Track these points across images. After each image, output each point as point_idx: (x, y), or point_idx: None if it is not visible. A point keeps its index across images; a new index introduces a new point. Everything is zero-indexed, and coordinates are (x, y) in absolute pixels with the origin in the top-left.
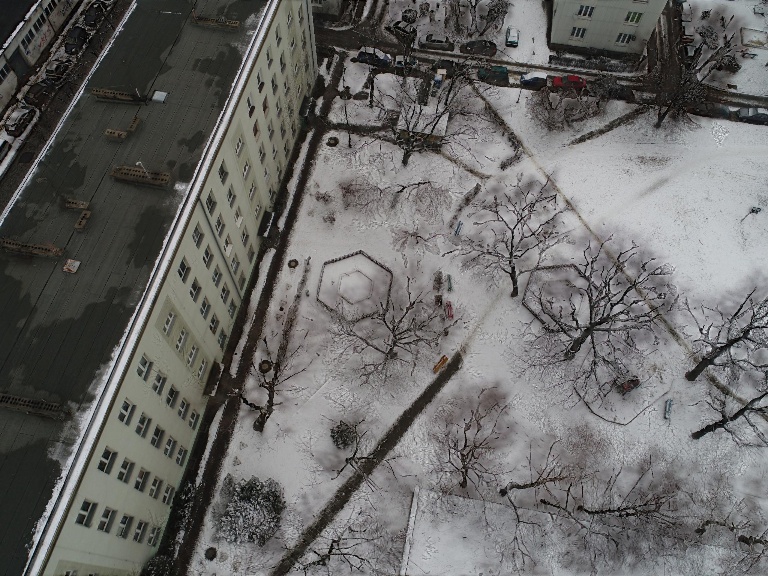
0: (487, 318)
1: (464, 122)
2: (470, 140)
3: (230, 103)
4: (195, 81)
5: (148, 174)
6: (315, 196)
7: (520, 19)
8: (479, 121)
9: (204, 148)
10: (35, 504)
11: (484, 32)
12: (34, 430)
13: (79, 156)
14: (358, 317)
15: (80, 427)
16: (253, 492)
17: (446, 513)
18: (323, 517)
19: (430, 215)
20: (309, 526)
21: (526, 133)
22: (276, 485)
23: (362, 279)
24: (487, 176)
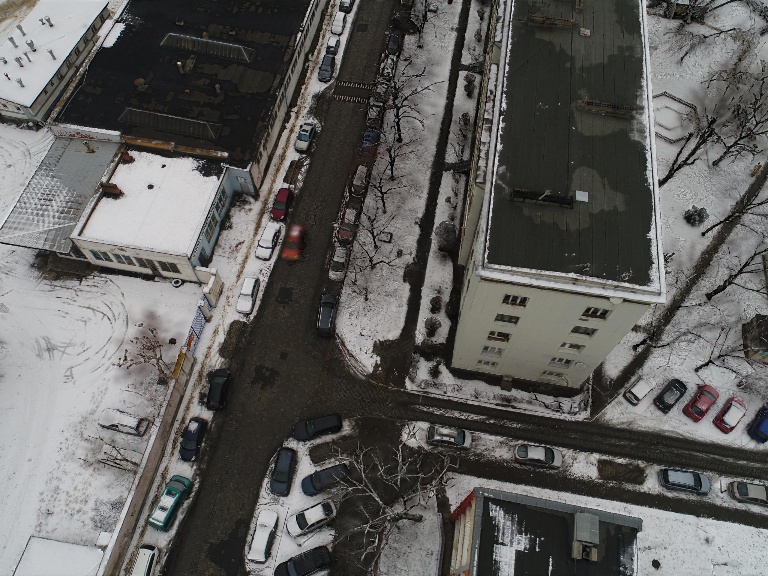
0: None
1: (717, 2)
2: (727, 15)
3: None
4: None
5: None
6: None
7: None
8: None
9: None
10: (639, 163)
11: None
12: (614, 124)
13: None
14: None
15: (644, 123)
16: None
17: None
18: (696, 270)
19: (743, 51)
20: (687, 276)
21: None
22: None
23: (671, 113)
24: None
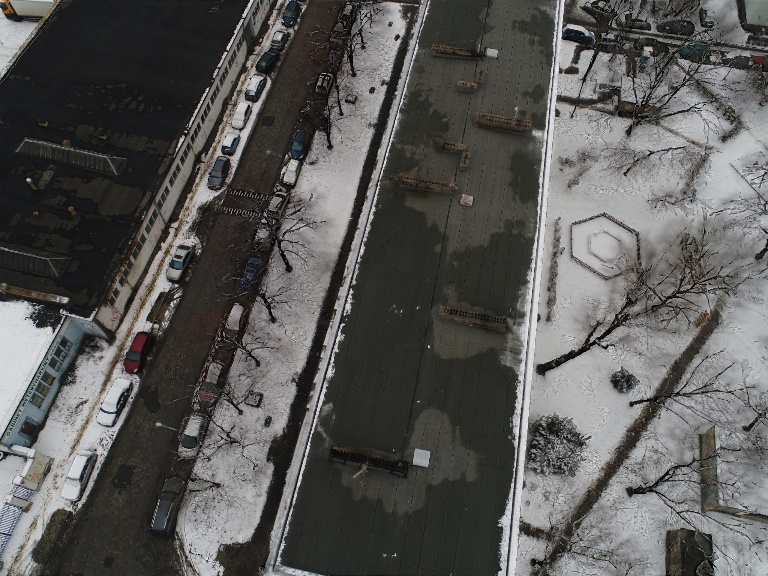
0: (737, 278)
1: (676, 96)
2: None
3: (555, 61)
4: (518, 40)
5: (511, 121)
6: (559, 160)
7: (710, 1)
8: (691, 96)
9: (547, 100)
10: (505, 403)
11: (680, 13)
12: (482, 340)
13: (436, 104)
14: (642, 269)
15: (521, 339)
16: (561, 427)
17: (747, 451)
18: (618, 454)
19: (691, 177)
20: (607, 462)
21: (739, 108)
22: (572, 423)
23: (610, 239)
24: (709, 147)
